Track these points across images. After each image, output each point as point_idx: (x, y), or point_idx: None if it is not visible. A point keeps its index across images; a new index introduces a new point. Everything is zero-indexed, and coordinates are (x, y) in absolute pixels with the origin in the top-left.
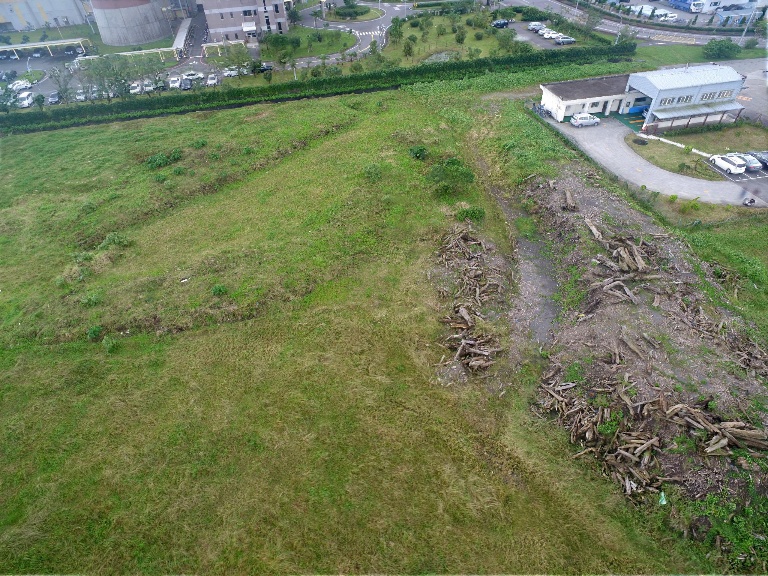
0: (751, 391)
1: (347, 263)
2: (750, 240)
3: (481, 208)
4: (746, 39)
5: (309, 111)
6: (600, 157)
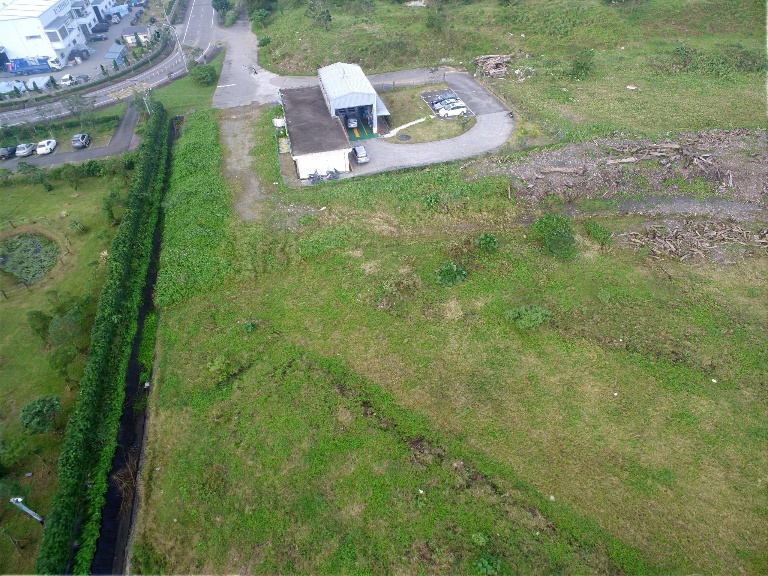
0: (766, 135)
1: (762, 327)
2: (563, 123)
3: (592, 223)
4: (170, 66)
5: (253, 453)
6: (440, 158)
